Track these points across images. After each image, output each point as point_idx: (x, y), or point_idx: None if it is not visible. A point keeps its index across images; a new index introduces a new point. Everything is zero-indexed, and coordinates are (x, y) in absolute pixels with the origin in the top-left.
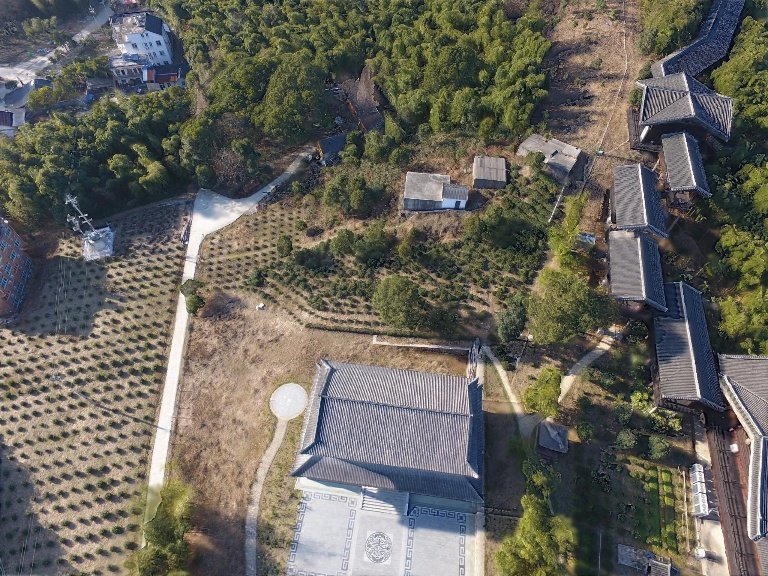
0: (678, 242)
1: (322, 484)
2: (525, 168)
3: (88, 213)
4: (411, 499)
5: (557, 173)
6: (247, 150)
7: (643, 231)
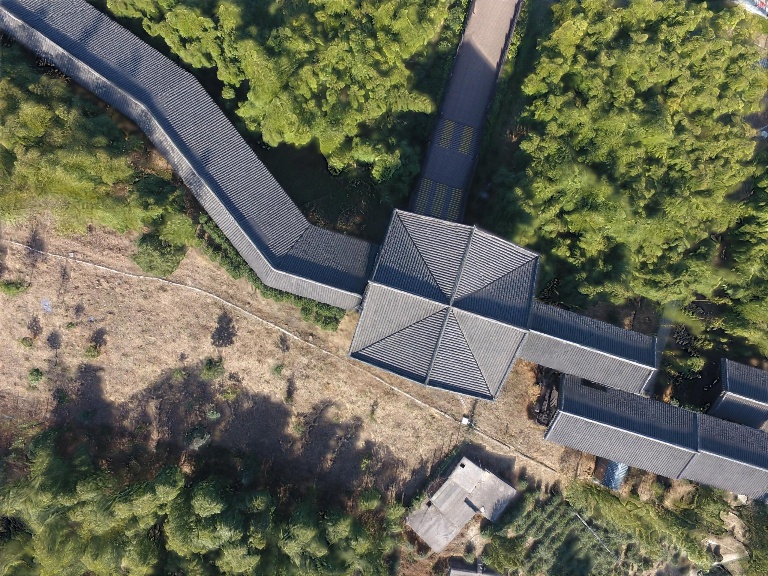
0: None
1: None
2: (473, 538)
3: None
4: None
5: None
6: None
7: None
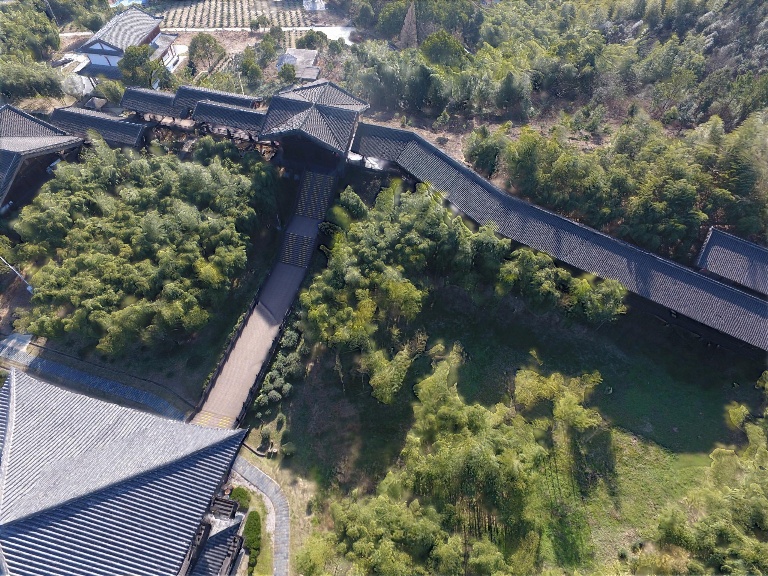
0: None
1: None
2: None
3: (345, 3)
4: None
5: None
6: (362, 10)
7: None
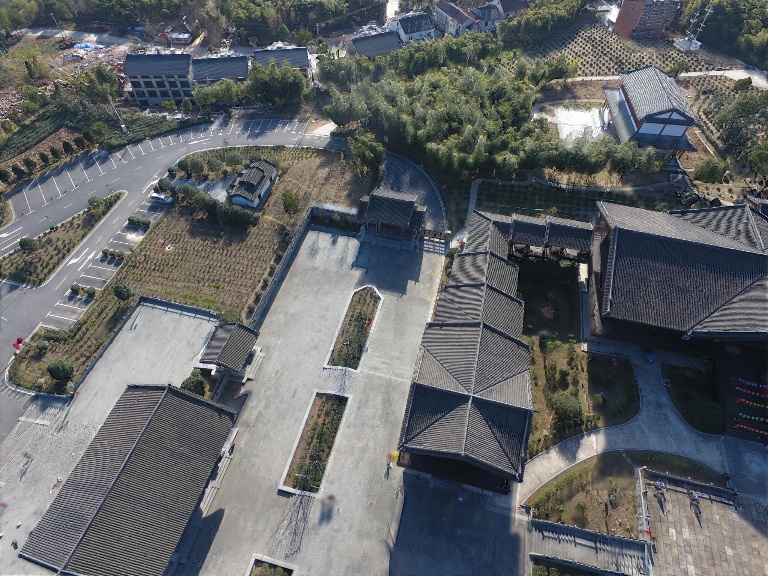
0: None
1: (599, 115)
2: None
3: (706, 41)
4: None
5: None
6: None
7: None
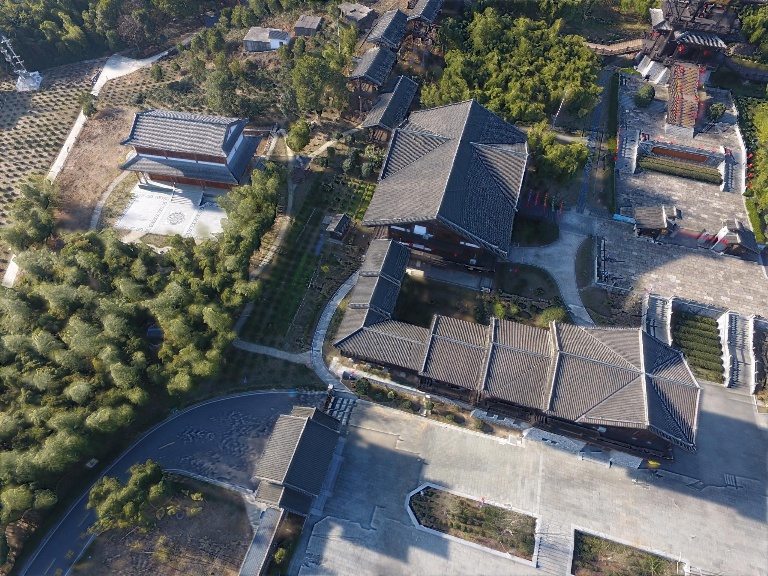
0: (430, 69)
1: (148, 191)
2: (334, 23)
3: (26, 67)
4: (205, 199)
5: (352, 23)
6: (143, 18)
7: (381, 43)
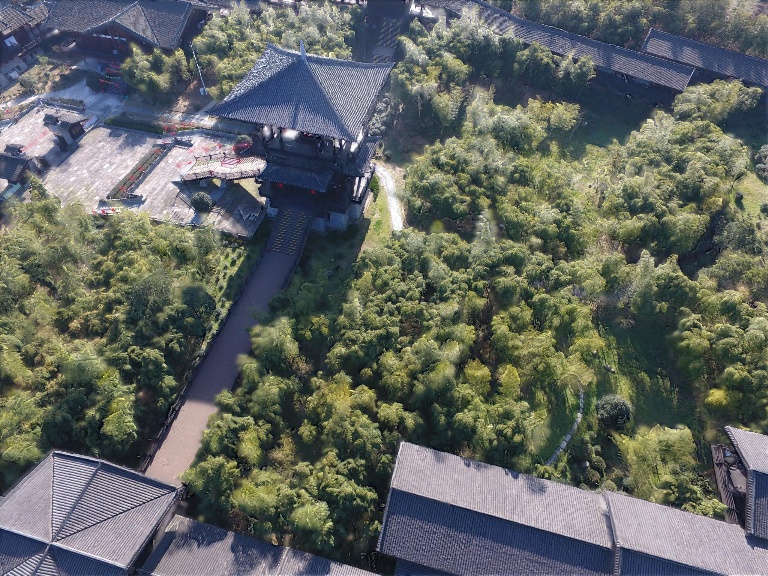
0: None
1: None
2: None
3: None
4: None
5: None
6: None
7: None
